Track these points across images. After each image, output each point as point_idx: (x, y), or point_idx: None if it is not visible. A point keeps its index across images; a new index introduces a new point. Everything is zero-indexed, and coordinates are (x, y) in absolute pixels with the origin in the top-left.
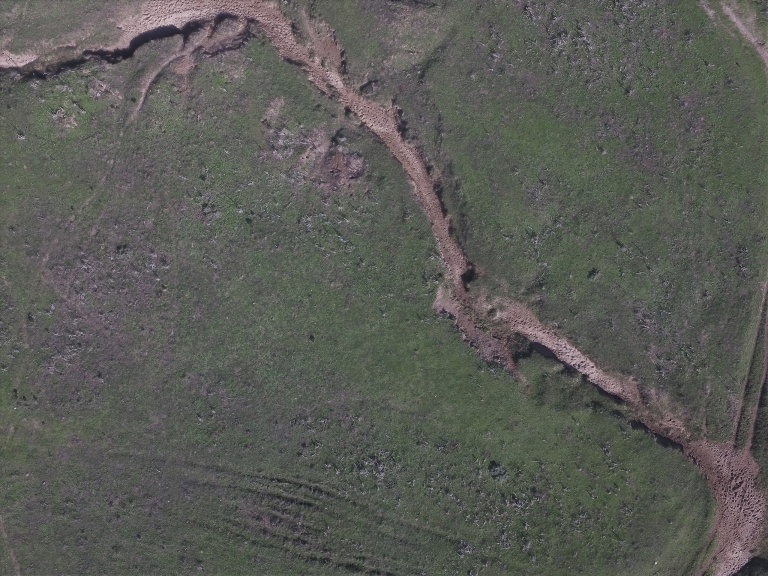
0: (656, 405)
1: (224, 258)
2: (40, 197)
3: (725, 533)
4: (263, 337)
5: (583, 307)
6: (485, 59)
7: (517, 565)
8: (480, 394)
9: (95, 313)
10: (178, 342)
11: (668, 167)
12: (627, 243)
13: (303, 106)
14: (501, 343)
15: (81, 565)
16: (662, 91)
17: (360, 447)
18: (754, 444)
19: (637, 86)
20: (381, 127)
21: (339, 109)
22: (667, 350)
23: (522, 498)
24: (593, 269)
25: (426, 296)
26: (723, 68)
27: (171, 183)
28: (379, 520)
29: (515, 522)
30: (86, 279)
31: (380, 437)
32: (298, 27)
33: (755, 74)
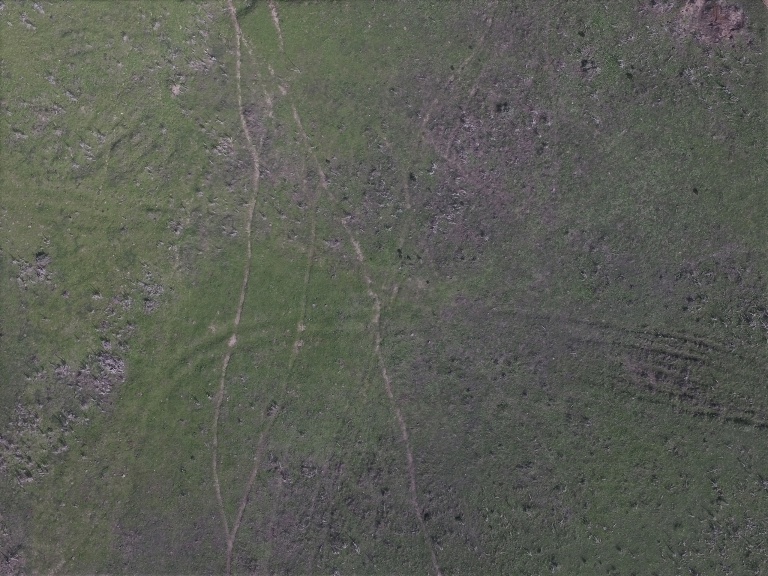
0: None
1: (604, 114)
2: (420, 58)
3: None
4: (646, 191)
5: None
6: None
7: None
8: None
9: (476, 172)
10: (560, 199)
11: None
12: None
13: None
14: None
15: (467, 424)
16: None
17: (747, 299)
18: None
19: None
20: None
21: None
22: None
23: None
24: None
25: None
26: None
27: (550, 40)
28: (767, 373)
29: None
30: (466, 138)
31: (767, 289)
32: None
33: None
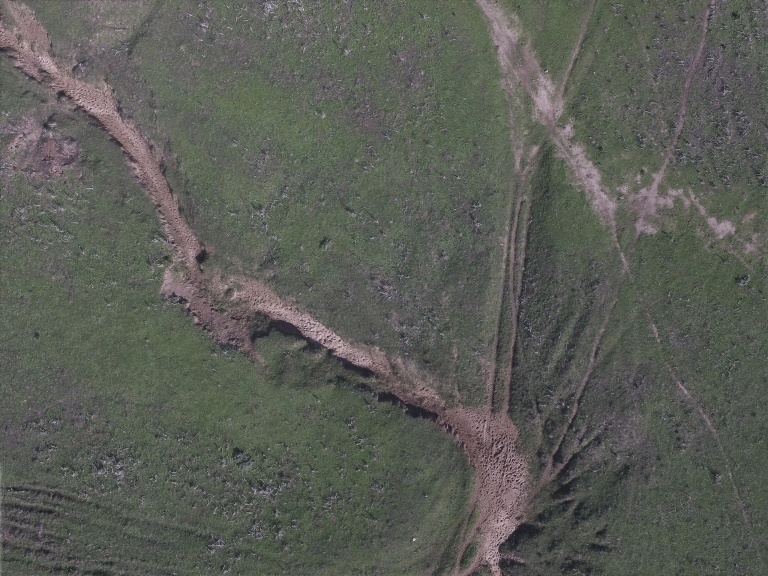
0: (406, 374)
1: None
2: None
3: (487, 501)
4: None
5: (318, 279)
6: (194, 30)
7: (271, 555)
8: (216, 379)
9: None
10: None
11: (391, 126)
12: (357, 208)
13: (9, 94)
14: (239, 324)
15: None
16: (380, 48)
17: (96, 446)
18: (510, 406)
19: (354, 45)
20: (100, 110)
21: (50, 94)
22: (409, 316)
23: (270, 484)
24: (324, 238)
25: (152, 281)
26: (440, 19)
27: None
28: (123, 521)
29: (265, 510)
30: None
31: (117, 433)
32: (1, 12)
33: (474, 23)
